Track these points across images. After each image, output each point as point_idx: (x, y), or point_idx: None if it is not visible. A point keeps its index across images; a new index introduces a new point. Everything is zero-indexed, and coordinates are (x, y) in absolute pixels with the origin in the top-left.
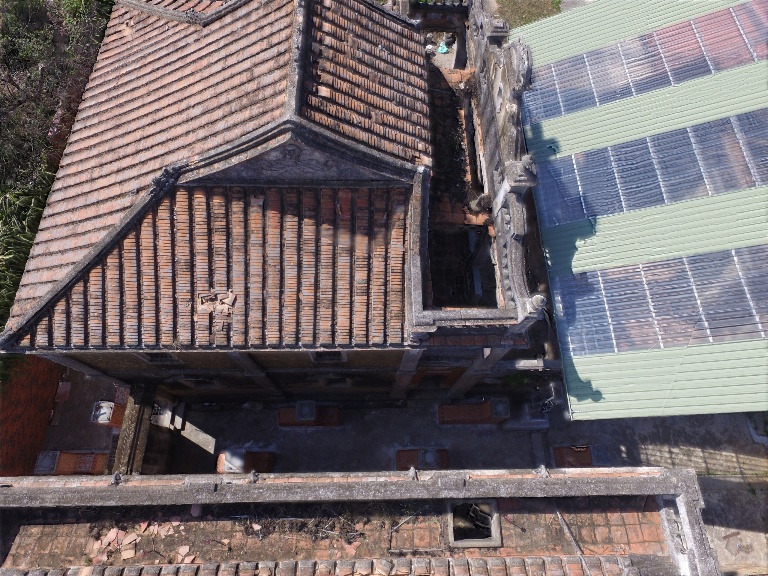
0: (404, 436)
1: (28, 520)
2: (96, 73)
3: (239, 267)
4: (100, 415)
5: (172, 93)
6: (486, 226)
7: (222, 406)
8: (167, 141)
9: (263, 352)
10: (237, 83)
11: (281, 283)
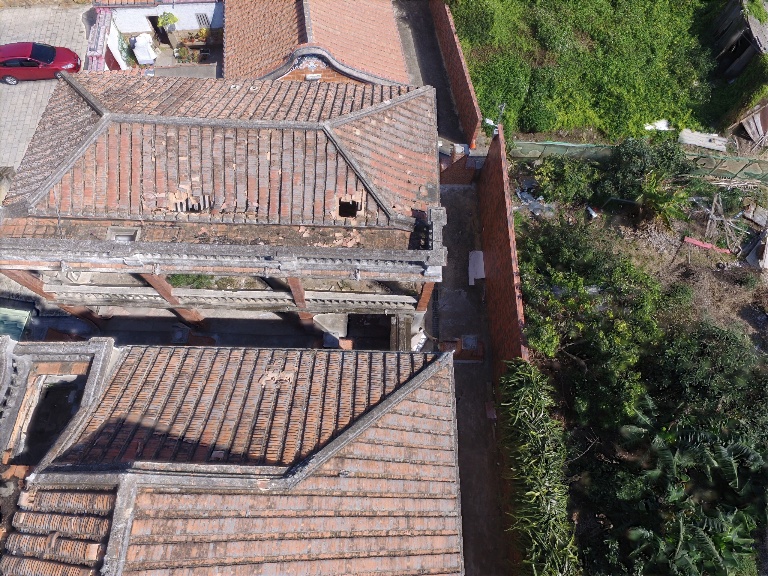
0: None
1: None
2: None
3: (251, 402)
4: None
5: None
6: (9, 464)
7: None
8: (310, 538)
9: None
10: None
11: None
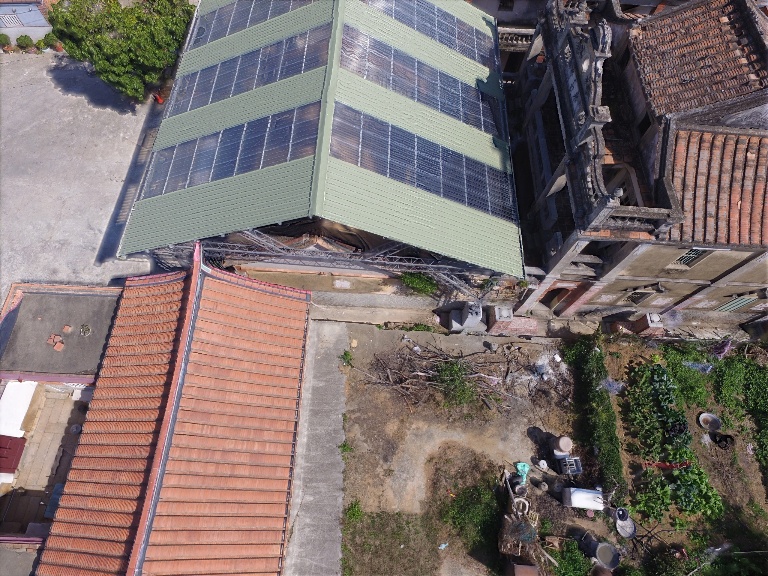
0: None
1: None
2: None
3: None
4: None
5: None
6: None
7: None
8: None
9: None
10: None
11: None
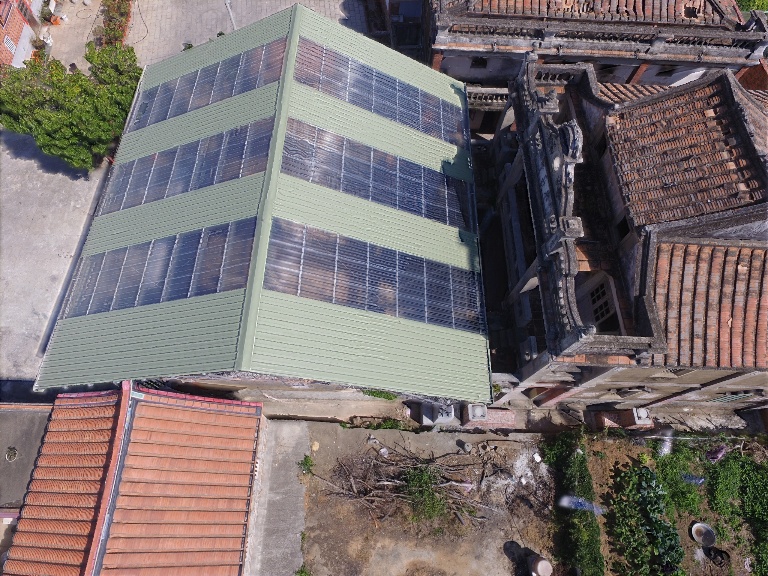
0: None
1: None
2: None
3: None
4: None
5: None
6: None
7: None
8: None
9: None
10: None
11: None
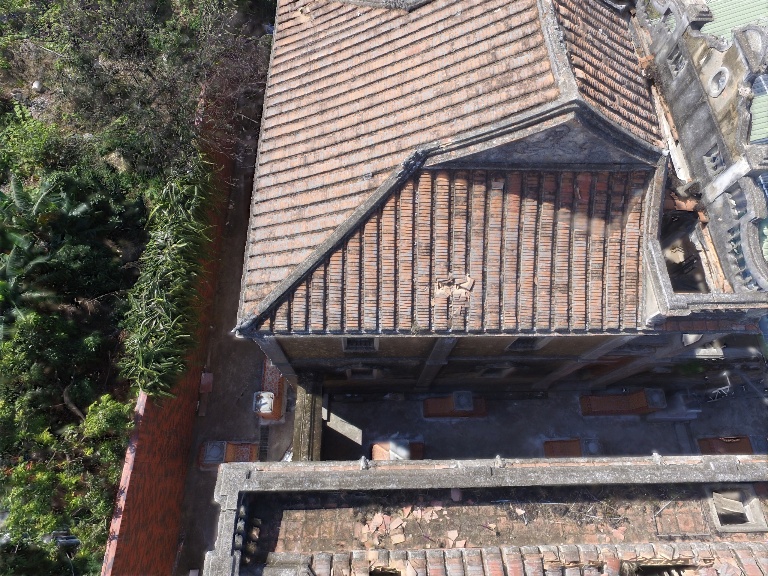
0: (549, 427)
1: (289, 505)
2: (279, 60)
3: (478, 251)
4: (262, 405)
5: (386, 78)
6: (696, 212)
7: (364, 397)
8: (395, 125)
9: (472, 339)
10: (476, 66)
11: (517, 267)
